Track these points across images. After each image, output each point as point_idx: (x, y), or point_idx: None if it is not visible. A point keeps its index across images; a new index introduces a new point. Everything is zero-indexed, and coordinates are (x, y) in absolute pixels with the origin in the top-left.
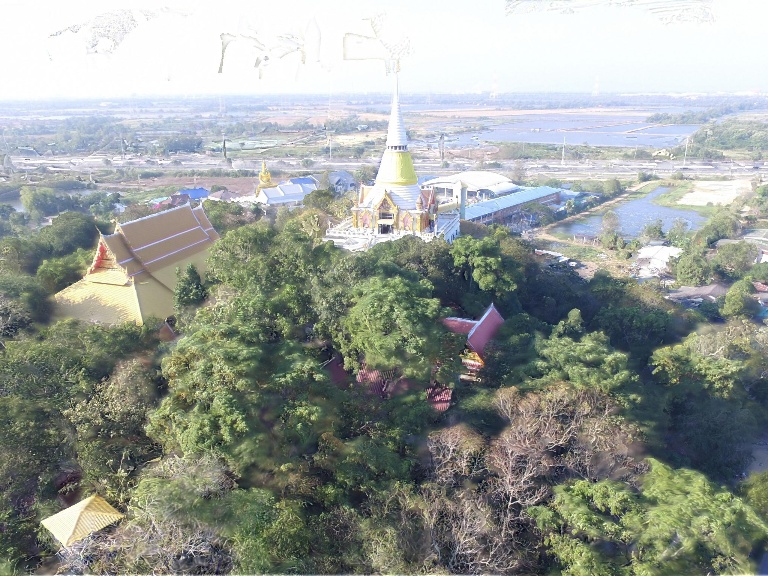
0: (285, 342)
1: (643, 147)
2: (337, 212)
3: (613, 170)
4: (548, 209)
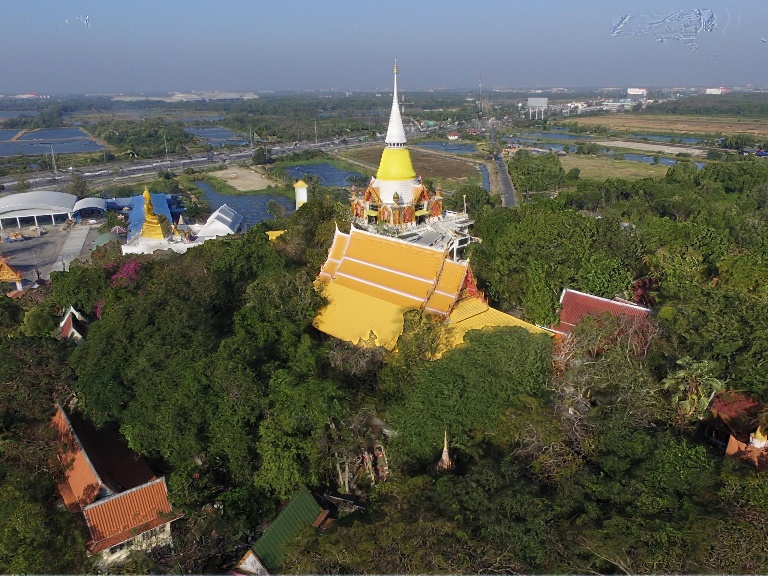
0: None
1: (109, 150)
2: (345, 219)
3: (122, 174)
4: None
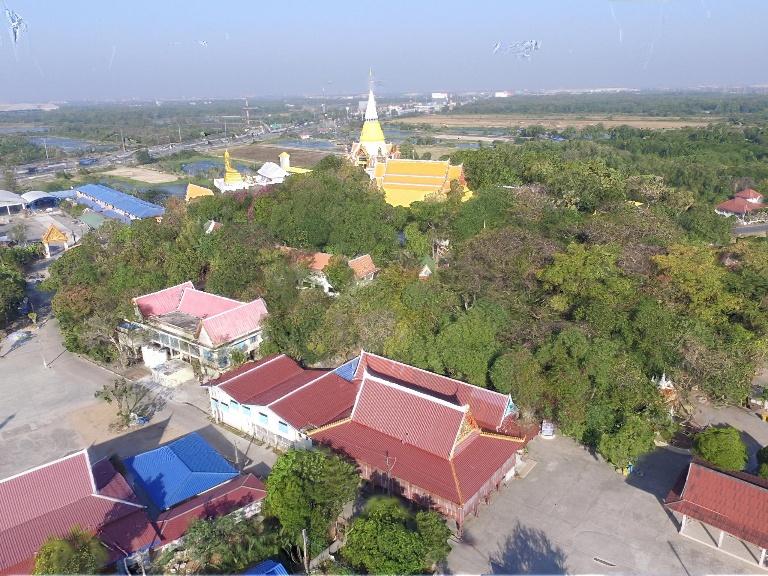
0: None
1: None
2: None
3: None
4: None
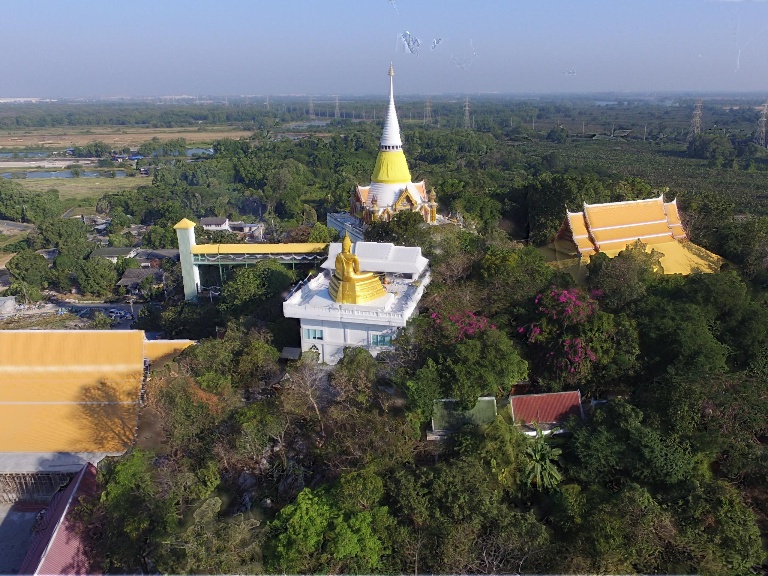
0: None
1: None
2: None
3: None
4: None
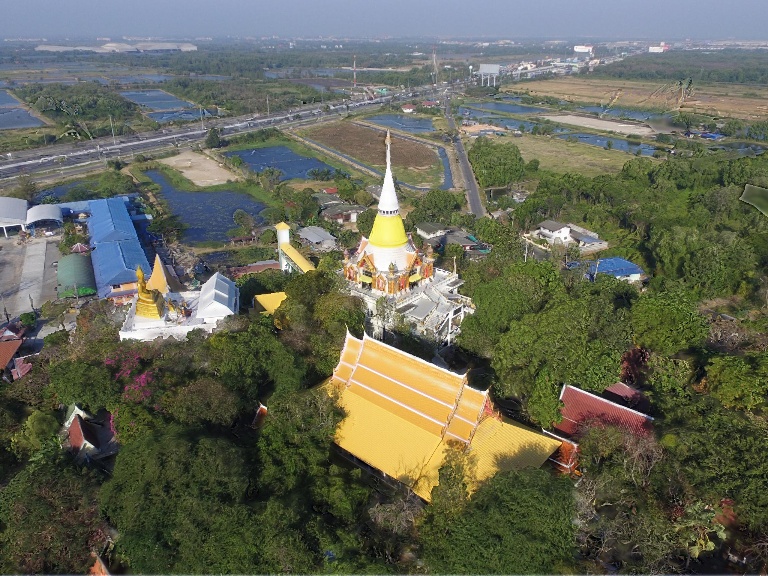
0: (724, 355)
1: (49, 131)
2: (340, 289)
3: (68, 163)
4: (178, 223)
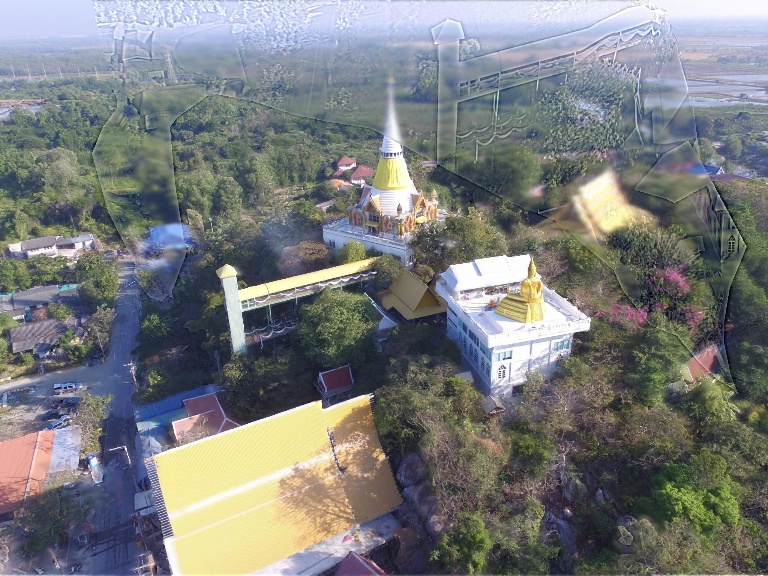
0: None
1: None
2: None
3: None
4: None
